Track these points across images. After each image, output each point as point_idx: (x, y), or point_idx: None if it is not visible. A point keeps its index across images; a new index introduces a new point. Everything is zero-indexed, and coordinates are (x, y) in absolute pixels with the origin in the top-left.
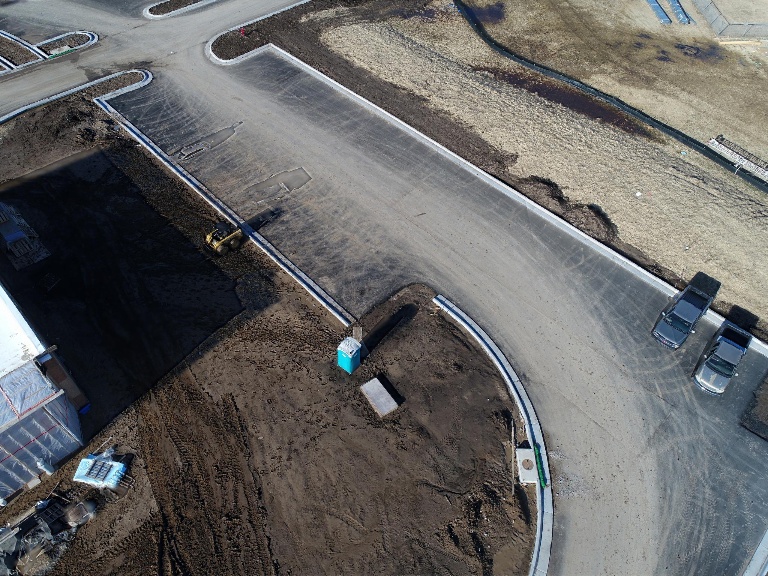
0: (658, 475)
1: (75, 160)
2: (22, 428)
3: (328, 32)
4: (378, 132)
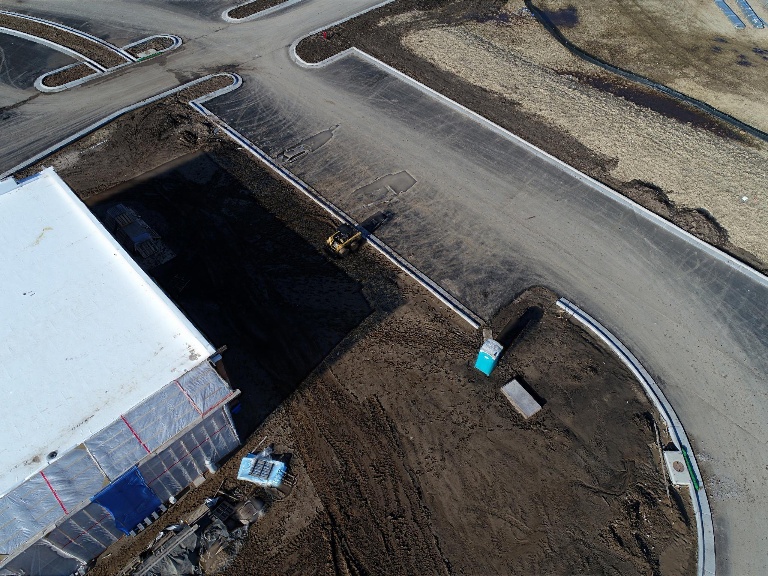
0: None
1: (182, 162)
2: (203, 427)
3: (409, 36)
4: (475, 136)
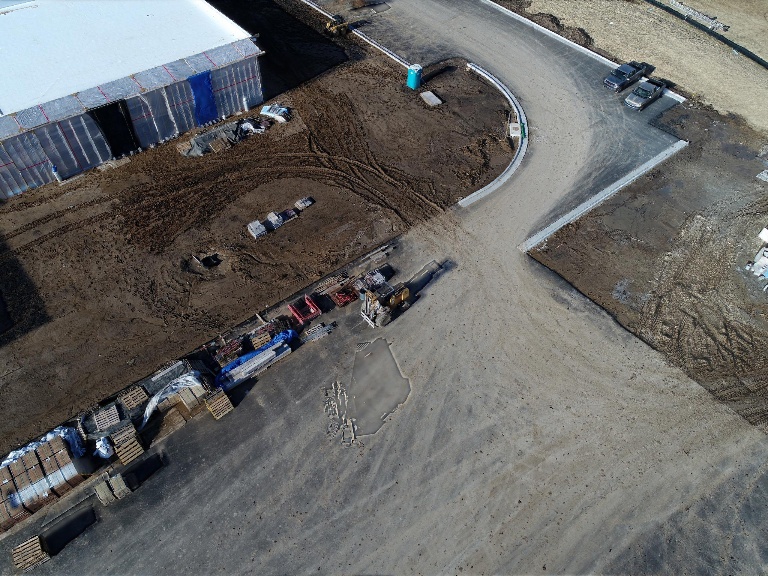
0: (592, 138)
1: None
2: (244, 67)
3: None
4: None
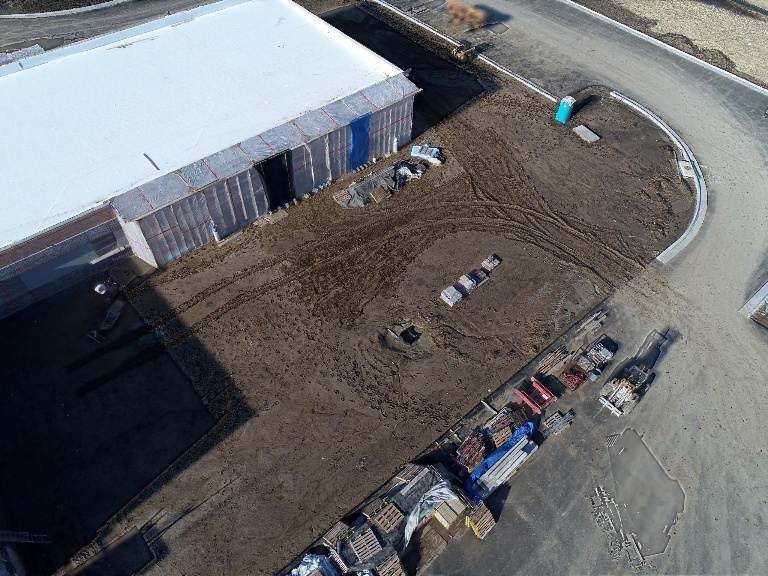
0: None
1: (342, 11)
2: (401, 106)
3: None
4: (550, 5)
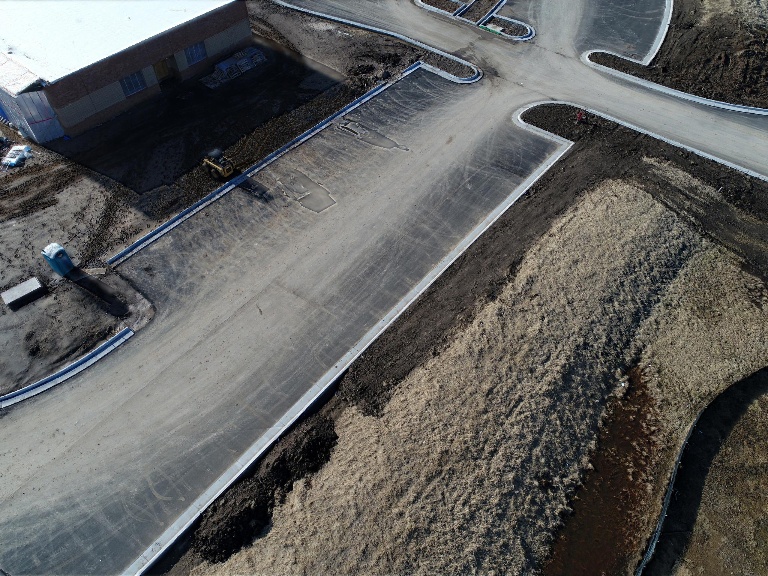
0: None
1: (327, 72)
2: None
3: (626, 184)
4: (412, 257)
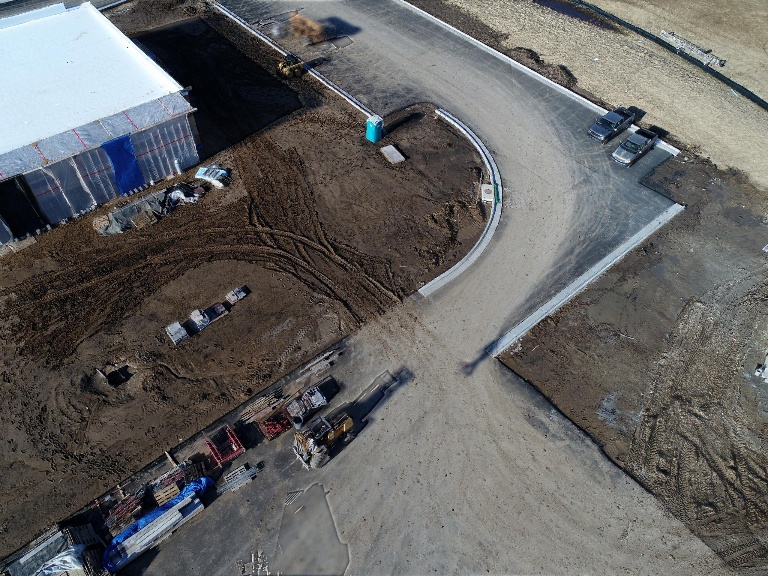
0: (575, 202)
1: (183, 23)
2: (172, 126)
3: None
4: (405, 18)
